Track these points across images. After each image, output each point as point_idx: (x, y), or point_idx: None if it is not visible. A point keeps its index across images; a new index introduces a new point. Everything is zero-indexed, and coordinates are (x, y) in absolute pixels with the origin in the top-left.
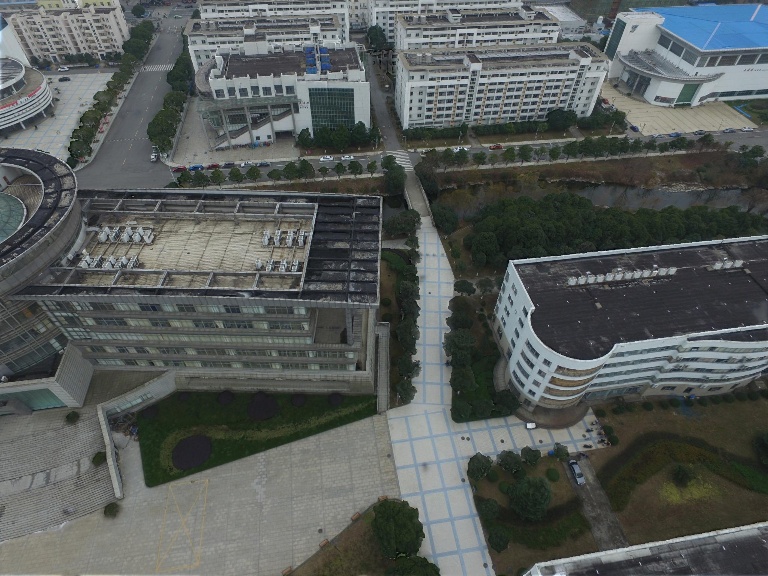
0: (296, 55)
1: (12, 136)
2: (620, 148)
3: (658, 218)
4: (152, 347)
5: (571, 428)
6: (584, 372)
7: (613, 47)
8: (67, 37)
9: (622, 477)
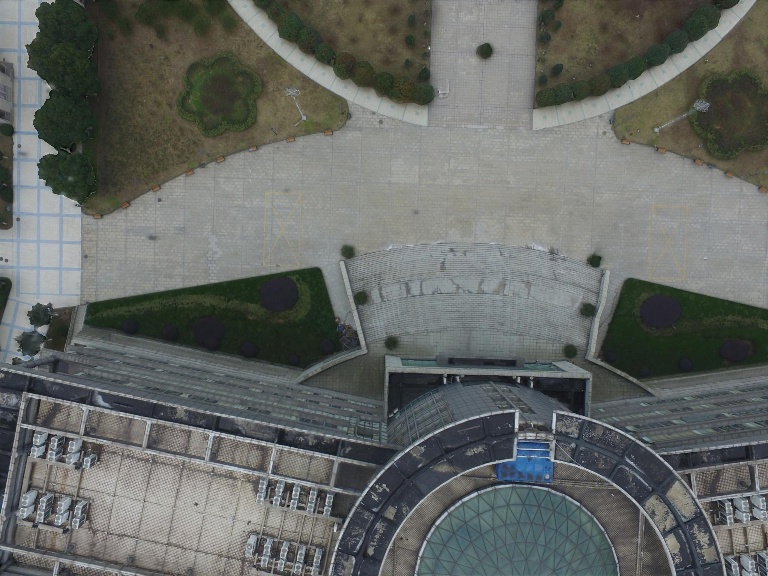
0: None
1: None
2: None
3: None
4: None
5: None
6: None
7: None
8: None
9: None
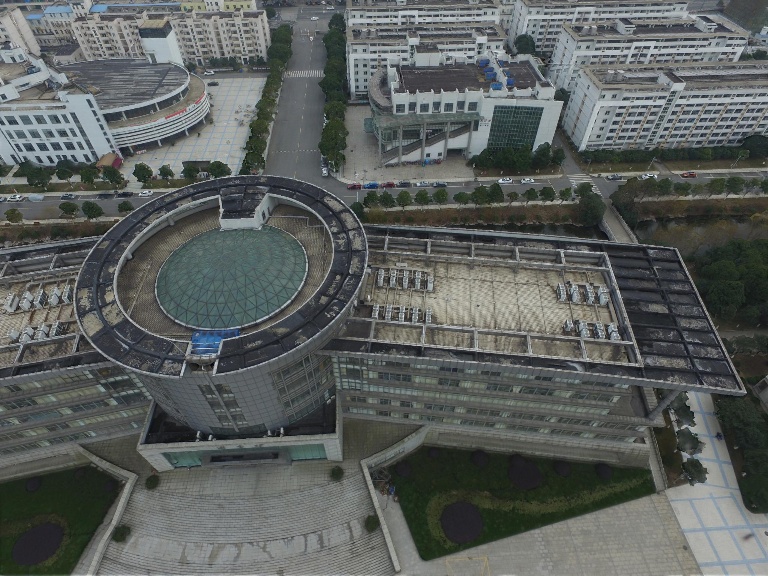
0: (470, 68)
1: (178, 143)
2: None
3: None
4: None
5: None
6: None
7: None
8: (214, 41)
9: None
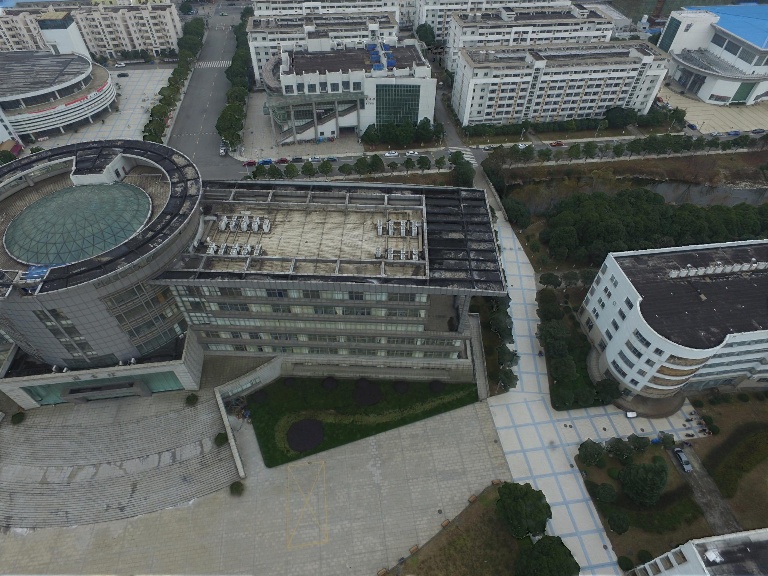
0: (359, 52)
1: (81, 130)
2: (684, 146)
3: (733, 214)
4: (266, 333)
5: (670, 417)
6: (696, 361)
7: (666, 46)
8: (124, 34)
9: (728, 465)
